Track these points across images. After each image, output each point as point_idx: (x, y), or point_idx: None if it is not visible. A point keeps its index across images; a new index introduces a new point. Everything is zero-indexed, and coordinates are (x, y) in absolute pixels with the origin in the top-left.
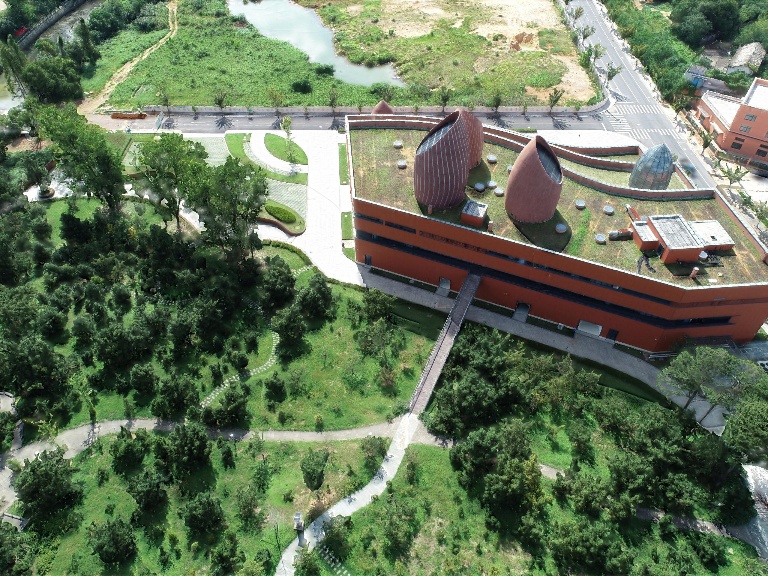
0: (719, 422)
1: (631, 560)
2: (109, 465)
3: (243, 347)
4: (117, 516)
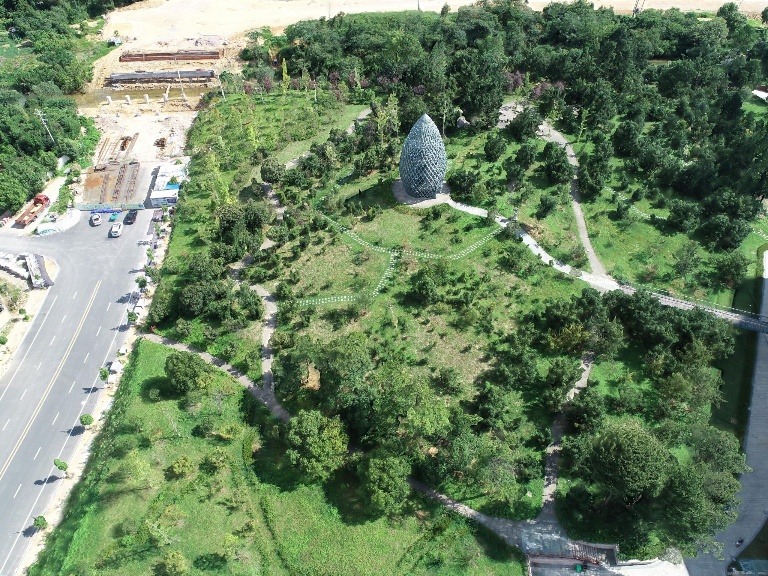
0: (694, 572)
1: (505, 377)
2: (542, 151)
3: (655, 201)
4: (511, 155)
